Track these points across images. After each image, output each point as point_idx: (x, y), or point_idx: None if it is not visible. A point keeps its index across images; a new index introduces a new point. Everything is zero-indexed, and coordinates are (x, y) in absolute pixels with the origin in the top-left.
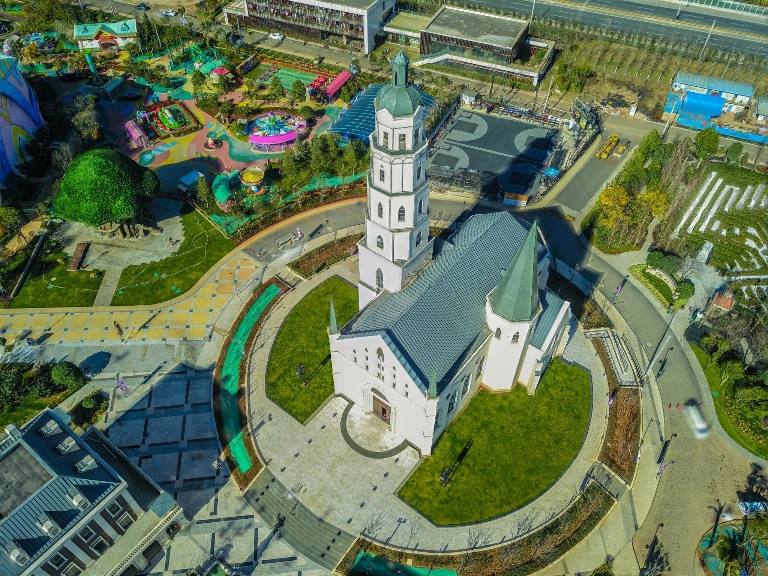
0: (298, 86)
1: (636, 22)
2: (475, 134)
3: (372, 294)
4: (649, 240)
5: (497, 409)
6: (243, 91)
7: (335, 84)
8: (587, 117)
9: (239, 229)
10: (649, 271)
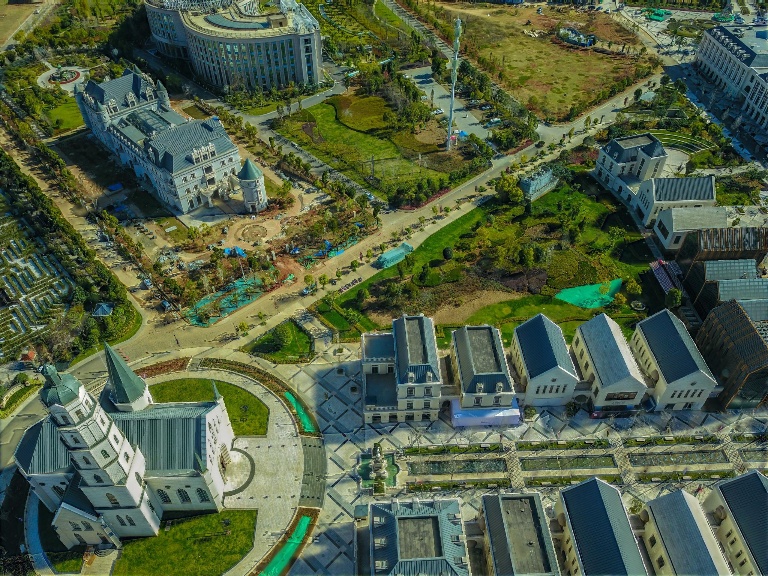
0: None
1: None
2: None
3: (145, 496)
4: None
5: None
6: None
7: None
8: None
9: None
10: (4, 405)
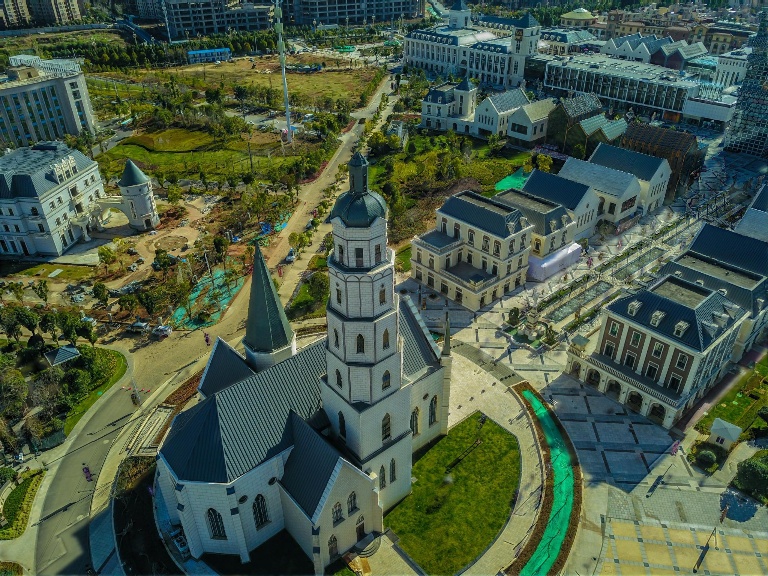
0: None
1: None
2: None
3: None
4: None
5: None
6: None
7: None
8: None
9: None
10: None
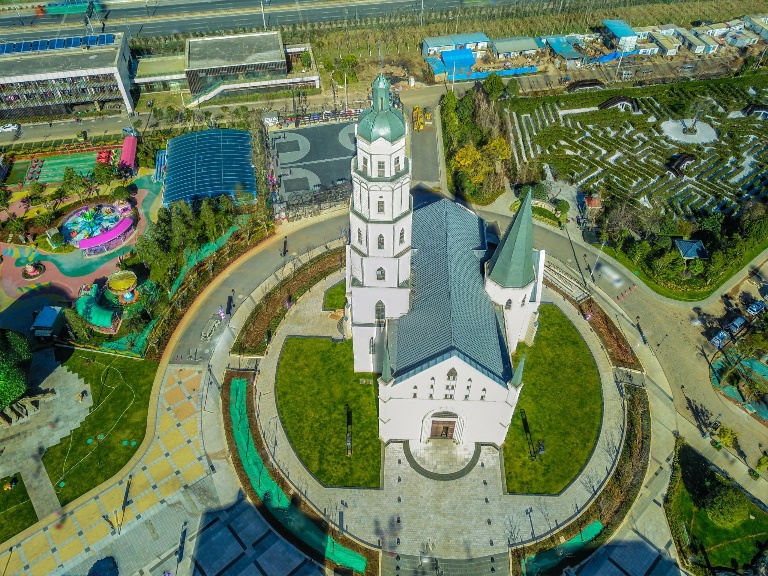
0: (102, 168)
1: (350, 8)
2: (302, 150)
3: (371, 330)
4: (505, 181)
5: None
6: (19, 200)
7: (129, 153)
8: (392, 99)
9: (153, 343)
10: None
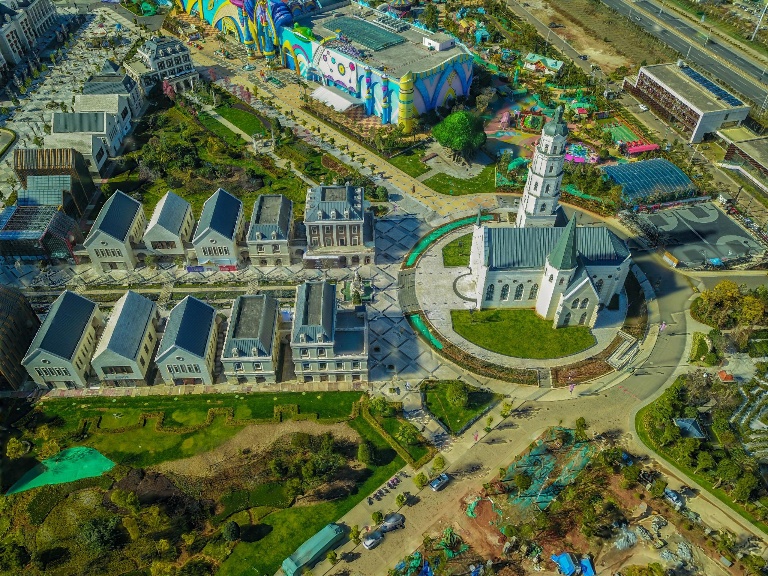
0: (607, 135)
1: None
2: (699, 219)
3: None
4: None
5: (530, 320)
6: None
7: (640, 148)
8: None
9: (502, 184)
10: (705, 339)
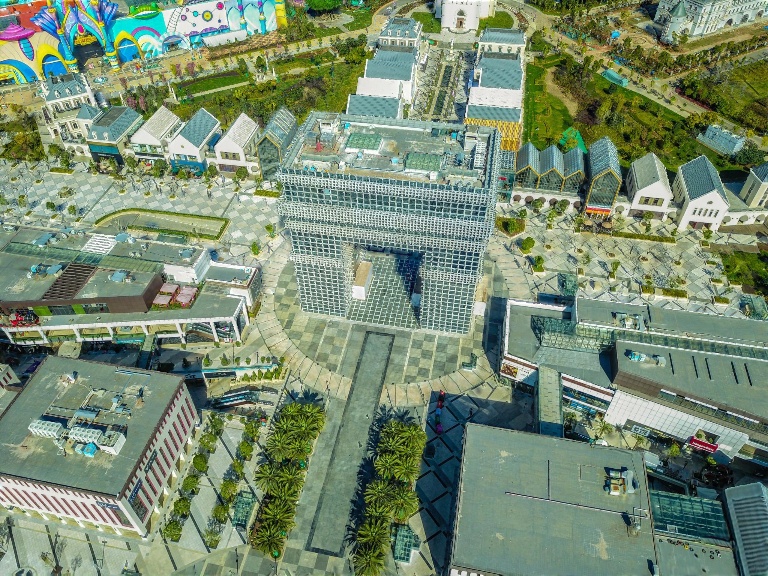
0: None
1: None
2: None
3: None
4: None
5: (488, 21)
6: None
7: None
8: None
9: None
10: None
